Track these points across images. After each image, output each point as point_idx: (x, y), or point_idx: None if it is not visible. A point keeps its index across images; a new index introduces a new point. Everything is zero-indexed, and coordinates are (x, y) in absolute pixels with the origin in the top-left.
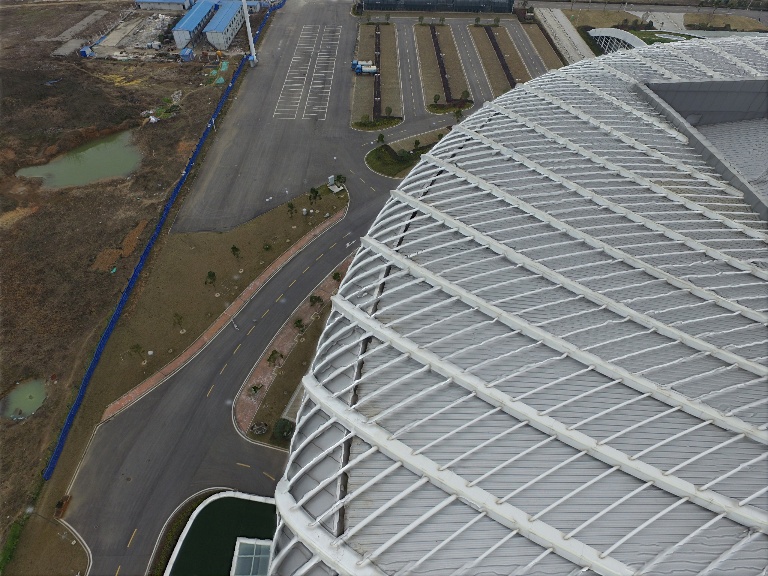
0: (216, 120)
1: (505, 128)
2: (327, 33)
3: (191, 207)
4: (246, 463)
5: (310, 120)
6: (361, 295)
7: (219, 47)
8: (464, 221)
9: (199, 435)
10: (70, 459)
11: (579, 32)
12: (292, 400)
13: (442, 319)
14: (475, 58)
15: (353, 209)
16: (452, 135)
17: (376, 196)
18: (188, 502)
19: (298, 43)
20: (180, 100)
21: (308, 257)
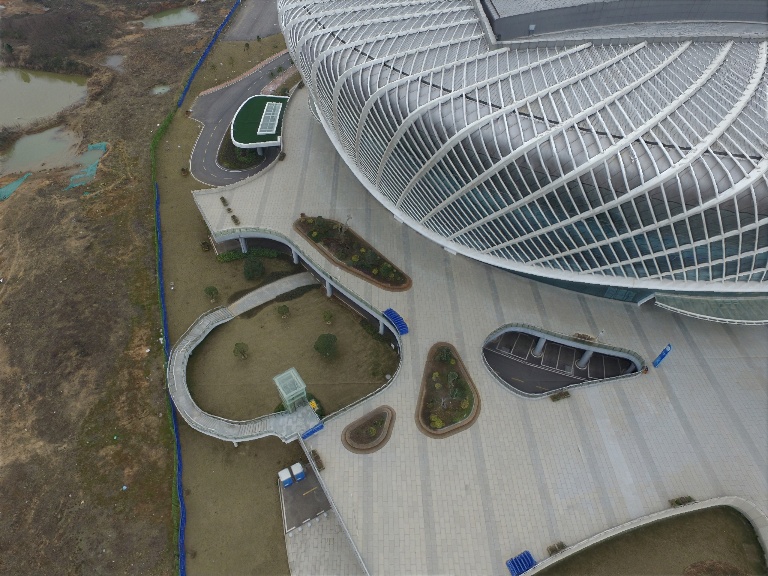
0: (241, 1)
1: None
2: None
3: (231, 33)
4: None
5: None
6: None
7: None
8: None
9: (246, 99)
10: (187, 104)
11: None
12: (289, 91)
13: None
14: None
15: None
16: None
17: None
18: None
19: None
20: None
21: None
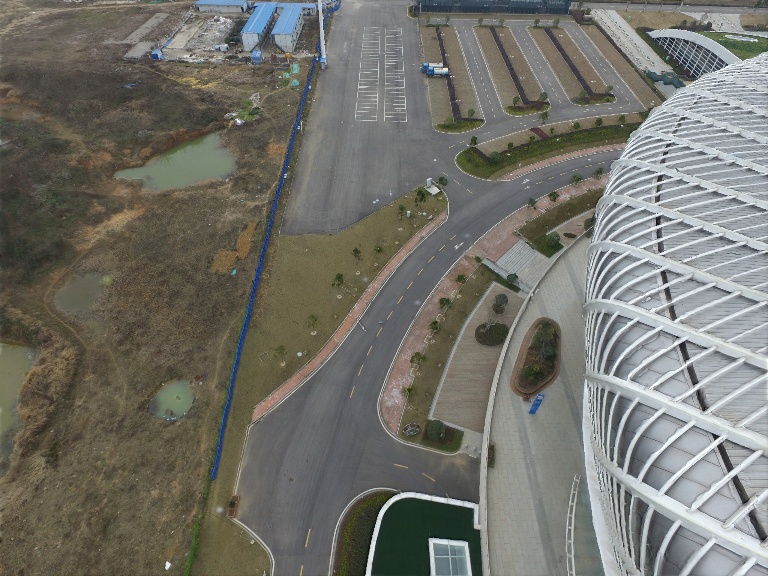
0: None
1: (706, 133)
2: (389, 35)
3: (295, 209)
4: (403, 464)
5: (392, 122)
6: (645, 300)
7: (286, 49)
8: (724, 226)
9: (351, 436)
10: (230, 459)
11: (639, 33)
12: (435, 402)
13: (762, 324)
14: (541, 60)
15: (454, 211)
16: (648, 140)
17: (474, 198)
18: (356, 502)
19: (363, 45)
20: (260, 102)
21: (420, 259)
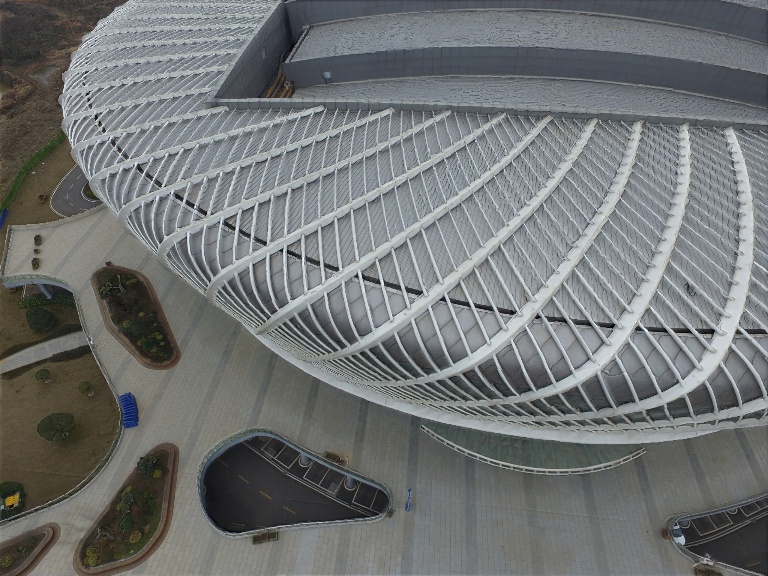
0: None
1: None
2: None
3: None
4: None
5: None
6: None
7: None
8: None
9: None
10: None
11: None
12: None
13: None
14: None
15: None
16: None
17: None
18: None
19: None
20: None
21: None
